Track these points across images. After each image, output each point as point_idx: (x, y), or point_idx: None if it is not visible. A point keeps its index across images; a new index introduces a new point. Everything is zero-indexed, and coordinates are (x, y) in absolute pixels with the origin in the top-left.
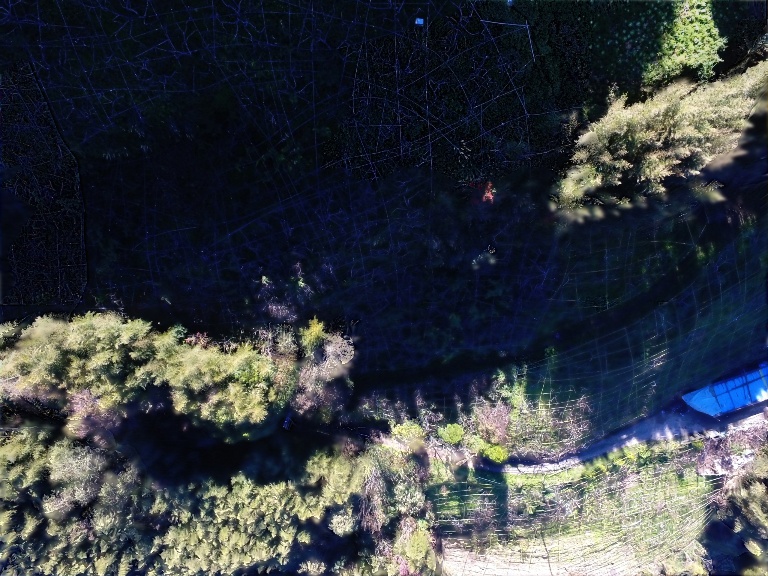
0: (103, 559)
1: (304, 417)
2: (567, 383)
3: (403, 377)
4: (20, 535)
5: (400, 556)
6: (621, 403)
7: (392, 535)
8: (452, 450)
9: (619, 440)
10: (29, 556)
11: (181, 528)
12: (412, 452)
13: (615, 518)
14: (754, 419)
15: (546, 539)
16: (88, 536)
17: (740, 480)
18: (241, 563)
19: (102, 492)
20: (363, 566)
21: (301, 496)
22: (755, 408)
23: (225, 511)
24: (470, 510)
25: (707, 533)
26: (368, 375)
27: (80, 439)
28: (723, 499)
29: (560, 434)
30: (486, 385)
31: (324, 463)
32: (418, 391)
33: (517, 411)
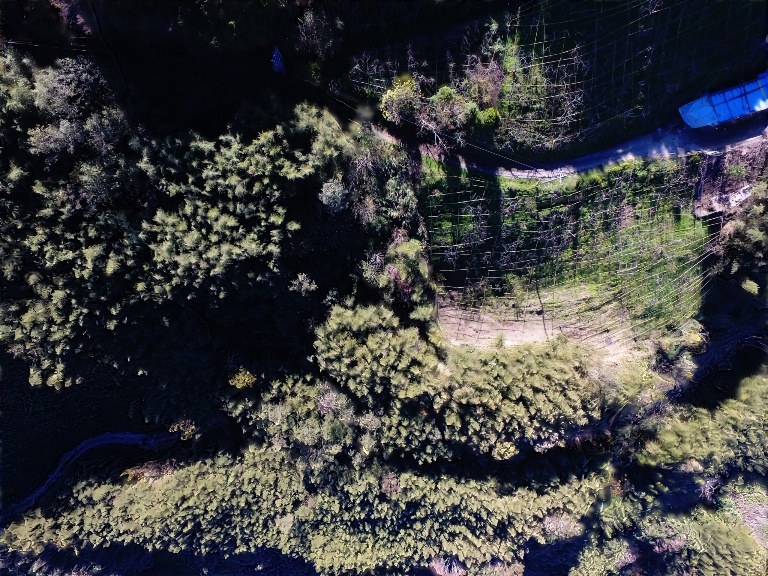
0: (91, 248)
1: (292, 48)
2: (561, 28)
3: (394, 39)
4: (6, 189)
5: (392, 266)
6: (616, 73)
7: (384, 248)
8: (445, 145)
9: (615, 154)
10: (15, 224)
11: (170, 214)
12: (404, 147)
13: (610, 258)
14: (752, 142)
15: (541, 291)
16: (75, 205)
17: (737, 217)
18: (230, 254)
19: (87, 125)
20: (355, 291)
21: (290, 150)
22: (753, 131)
23: (213, 175)
24: (463, 229)
25: (704, 310)
26: (358, 30)
27: (63, 20)
28: (720, 245)
29: (554, 108)
30: (478, 37)
31: (313, 110)
32: (409, 46)
33: (510, 79)
